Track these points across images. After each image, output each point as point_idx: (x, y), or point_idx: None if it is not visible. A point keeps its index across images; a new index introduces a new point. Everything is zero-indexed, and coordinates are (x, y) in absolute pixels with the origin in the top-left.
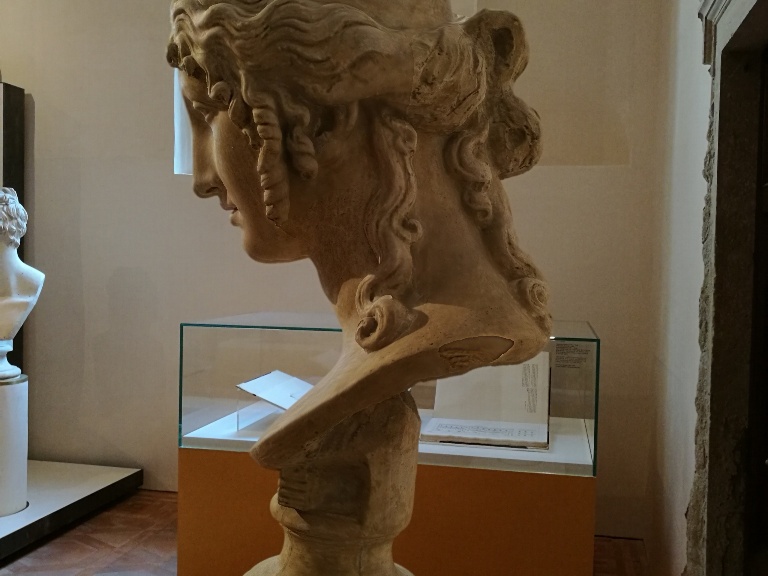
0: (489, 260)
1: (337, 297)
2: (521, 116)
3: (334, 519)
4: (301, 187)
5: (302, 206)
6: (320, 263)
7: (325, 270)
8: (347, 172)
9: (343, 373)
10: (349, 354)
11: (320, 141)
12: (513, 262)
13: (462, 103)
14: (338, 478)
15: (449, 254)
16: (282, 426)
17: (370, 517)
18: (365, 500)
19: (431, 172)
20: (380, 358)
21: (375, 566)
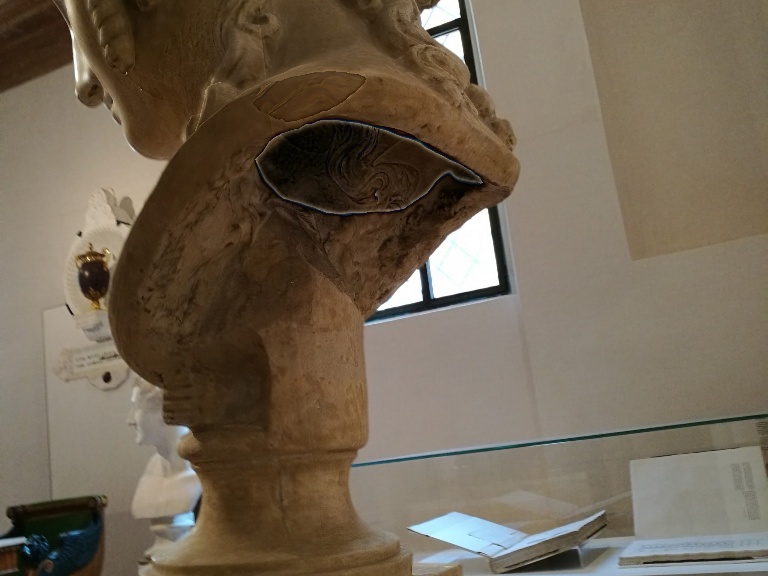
0: (375, 45)
1: None
2: None
3: (232, 430)
4: (149, 28)
5: (157, 52)
6: None
7: None
8: None
9: None
10: None
11: None
12: (405, 39)
13: None
14: (240, 380)
15: (313, 41)
16: None
17: (276, 419)
18: (267, 396)
19: None
20: None
21: (307, 500)
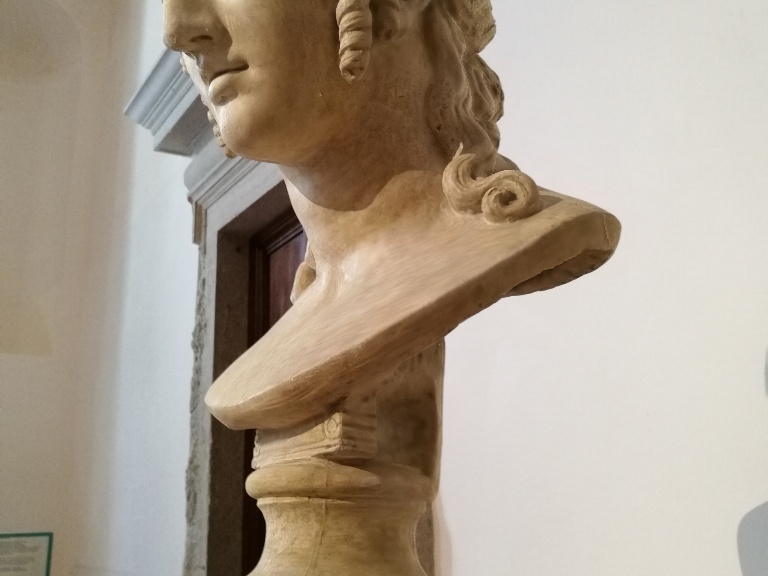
0: None
1: (375, 196)
2: (493, 75)
3: (402, 469)
4: None
5: None
6: (352, 155)
7: (361, 162)
8: (406, 53)
9: (490, 241)
10: (433, 247)
11: None
12: None
13: (490, 30)
14: (387, 421)
15: None
16: (431, 299)
17: (436, 465)
18: (431, 443)
19: None
20: (548, 218)
21: None
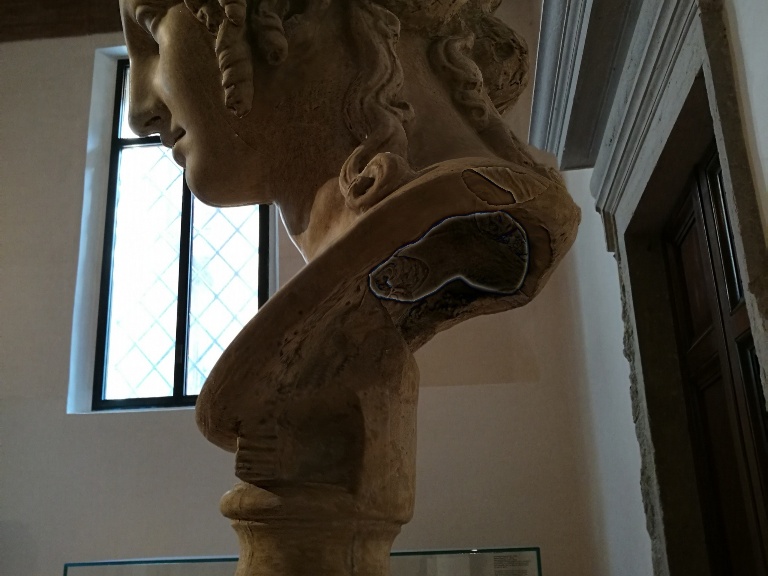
0: None
1: (309, 214)
2: (506, 31)
3: (316, 488)
4: (266, 80)
5: (266, 105)
6: (287, 180)
7: (294, 185)
8: (320, 63)
9: None
10: None
11: (289, 24)
12: (521, 155)
13: None
14: (318, 439)
15: (448, 136)
16: None
17: (366, 481)
18: (358, 458)
19: (416, 68)
20: (384, 199)
21: (372, 569)
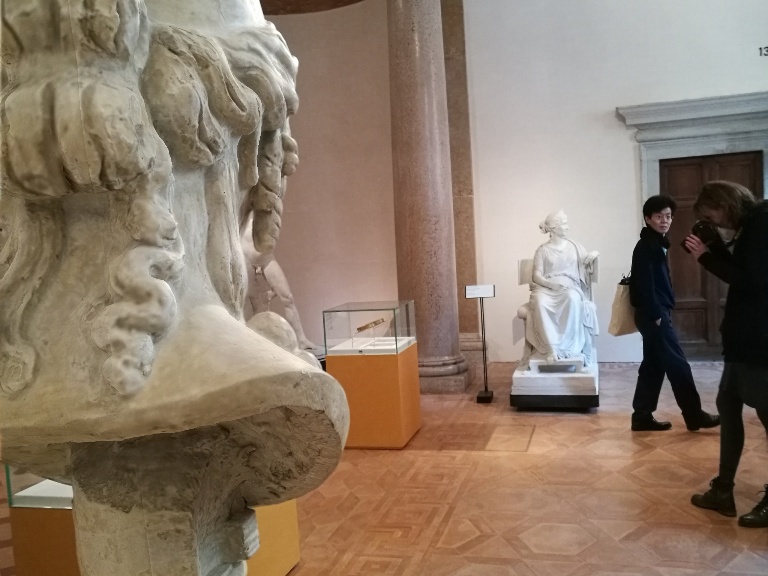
0: None
1: None
2: None
3: None
4: None
5: None
6: None
7: None
8: None
9: None
10: None
11: None
12: None
13: None
14: None
15: None
16: None
17: None
18: None
19: None
20: None
21: None
